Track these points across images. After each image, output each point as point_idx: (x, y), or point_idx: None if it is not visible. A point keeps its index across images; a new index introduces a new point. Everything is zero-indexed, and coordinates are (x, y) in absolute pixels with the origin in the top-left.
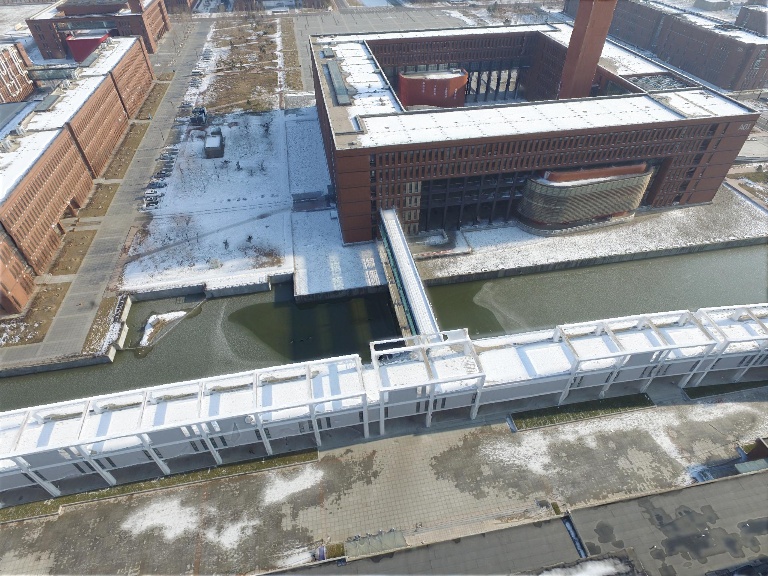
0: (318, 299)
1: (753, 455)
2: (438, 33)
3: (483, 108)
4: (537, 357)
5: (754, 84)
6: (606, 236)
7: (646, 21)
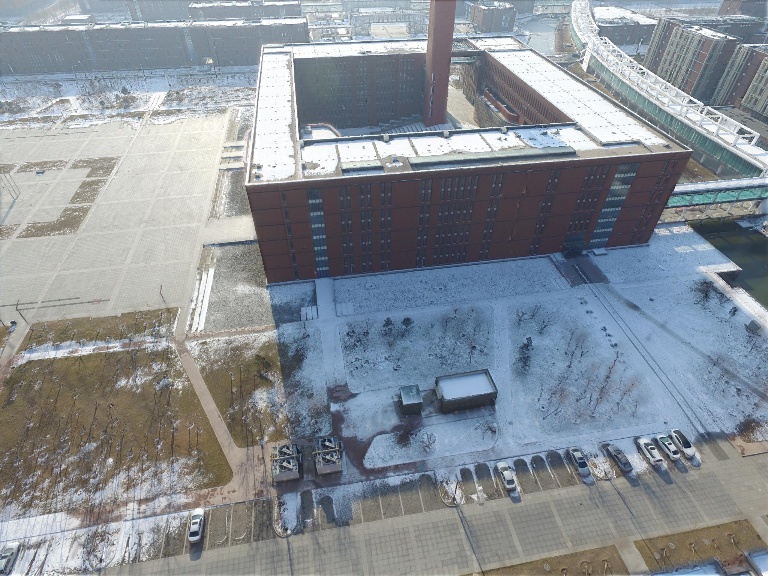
0: None
1: None
2: (272, 100)
3: None
4: None
5: None
6: None
7: (165, 41)
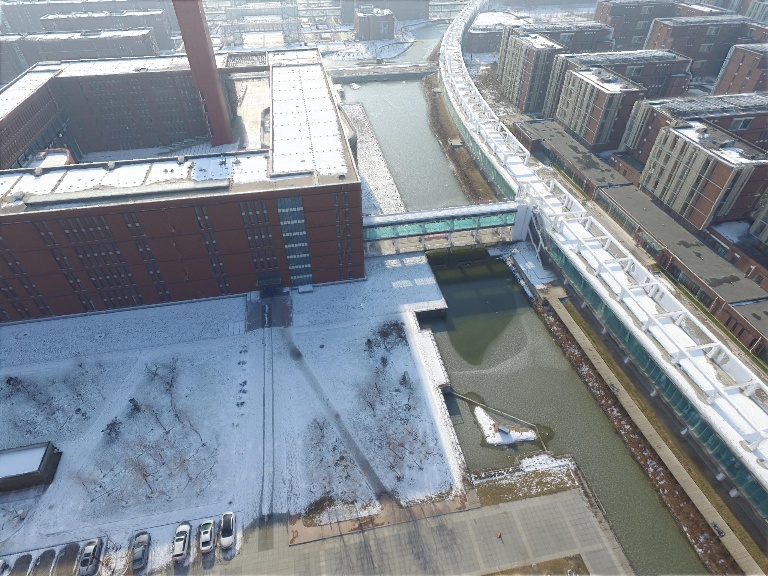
0: None
1: None
2: None
3: None
4: (520, 172)
5: None
6: (359, 155)
7: None
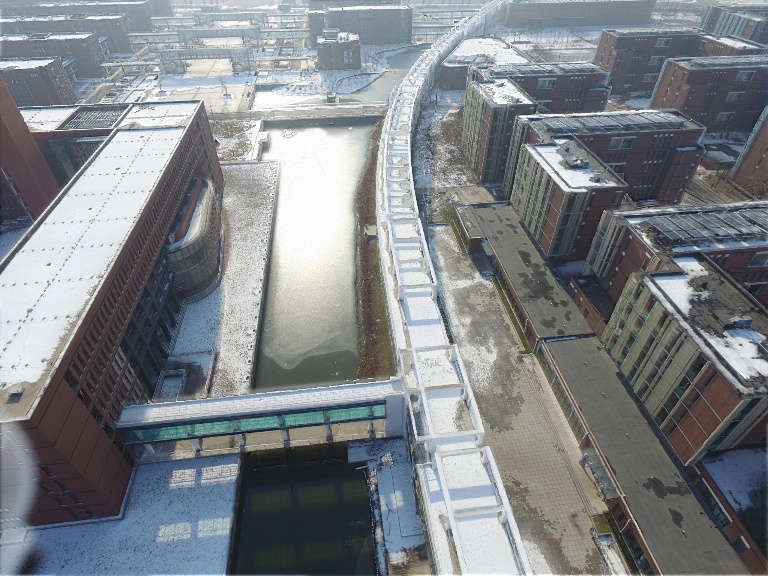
0: (230, 567)
1: (471, 249)
2: None
3: (31, 233)
4: (419, 314)
5: (71, 99)
6: (238, 247)
7: None
